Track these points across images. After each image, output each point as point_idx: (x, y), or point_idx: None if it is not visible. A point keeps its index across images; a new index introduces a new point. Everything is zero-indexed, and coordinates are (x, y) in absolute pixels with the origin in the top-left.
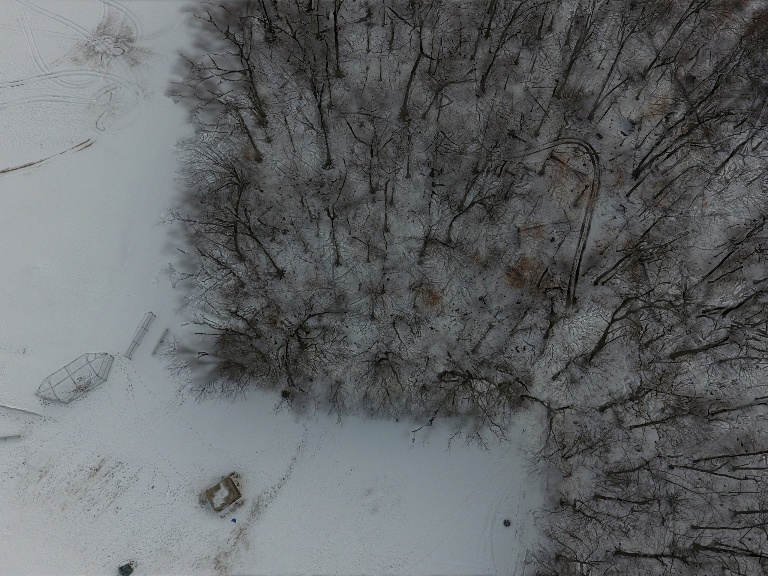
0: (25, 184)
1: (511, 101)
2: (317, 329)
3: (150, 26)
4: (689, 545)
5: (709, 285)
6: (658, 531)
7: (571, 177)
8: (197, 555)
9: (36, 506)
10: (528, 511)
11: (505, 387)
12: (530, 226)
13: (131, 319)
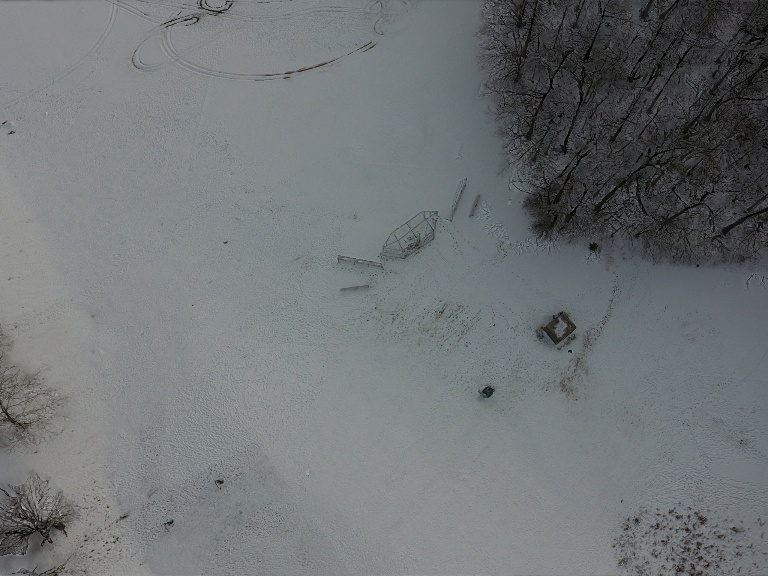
0: (323, 80)
1: (738, 2)
2: None
3: None
4: None
5: None
6: None
7: None
8: (544, 380)
9: (395, 343)
10: None
11: None
12: None
13: (445, 188)
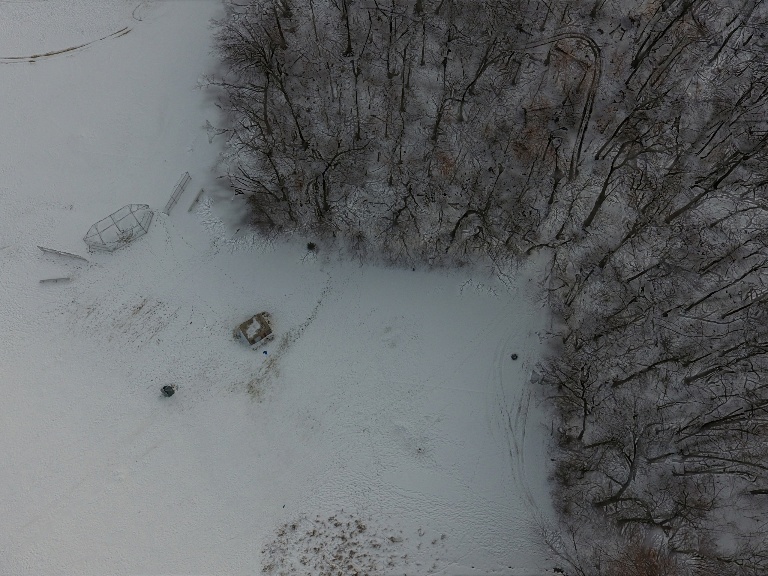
0: (68, 65)
1: None
2: (339, 193)
3: None
4: (681, 380)
5: (702, 160)
6: (652, 352)
7: (574, 66)
8: (232, 381)
9: (85, 337)
10: (534, 347)
11: (513, 243)
12: (536, 108)
13: (169, 181)
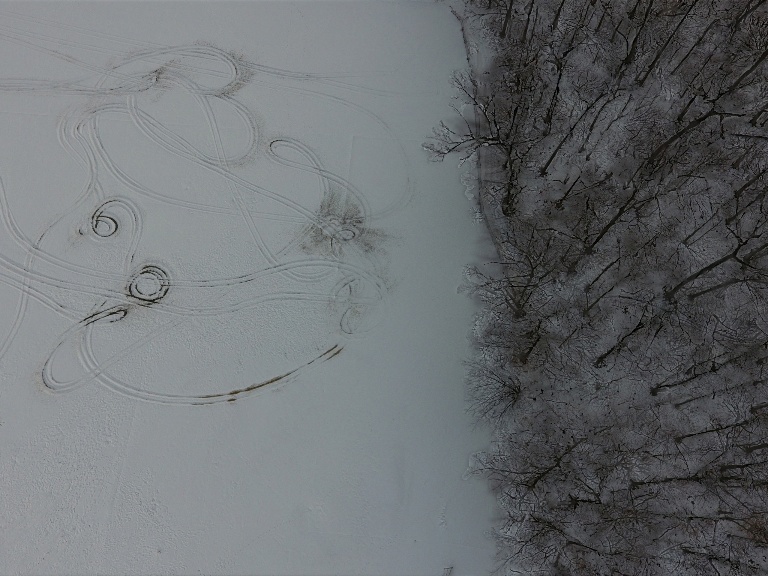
0: (276, 404)
1: None
2: (628, 571)
3: (377, 203)
4: None
5: None
6: None
7: None
8: None
9: None
10: None
11: None
12: None
13: (425, 572)
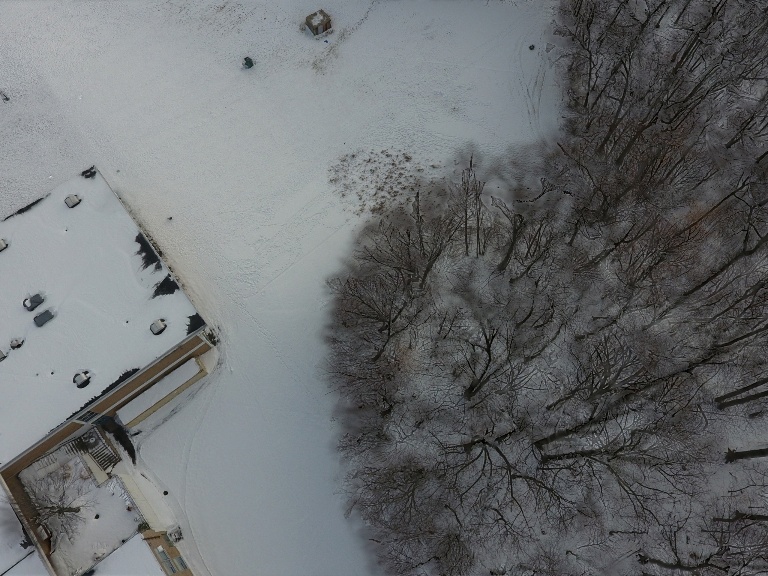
0: None
1: None
2: None
3: None
4: (670, 70)
5: None
6: None
7: None
8: (300, 60)
9: (179, 26)
10: (548, 42)
11: None
12: None
13: None
